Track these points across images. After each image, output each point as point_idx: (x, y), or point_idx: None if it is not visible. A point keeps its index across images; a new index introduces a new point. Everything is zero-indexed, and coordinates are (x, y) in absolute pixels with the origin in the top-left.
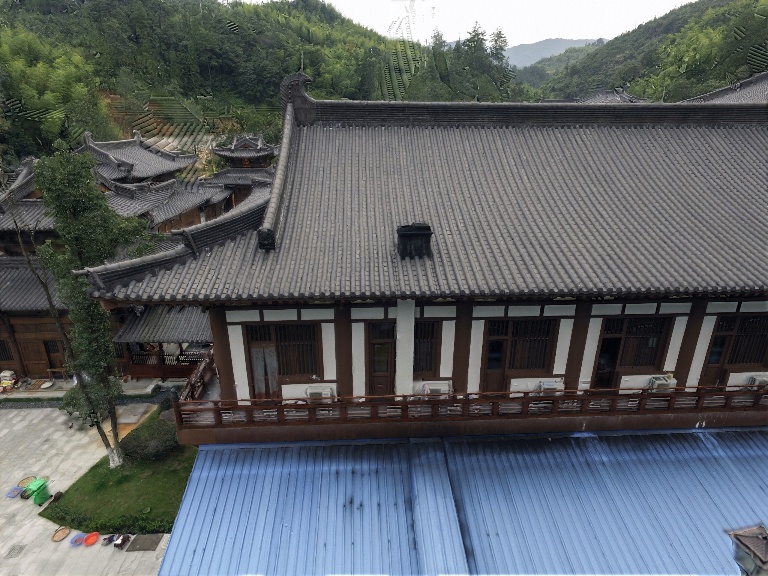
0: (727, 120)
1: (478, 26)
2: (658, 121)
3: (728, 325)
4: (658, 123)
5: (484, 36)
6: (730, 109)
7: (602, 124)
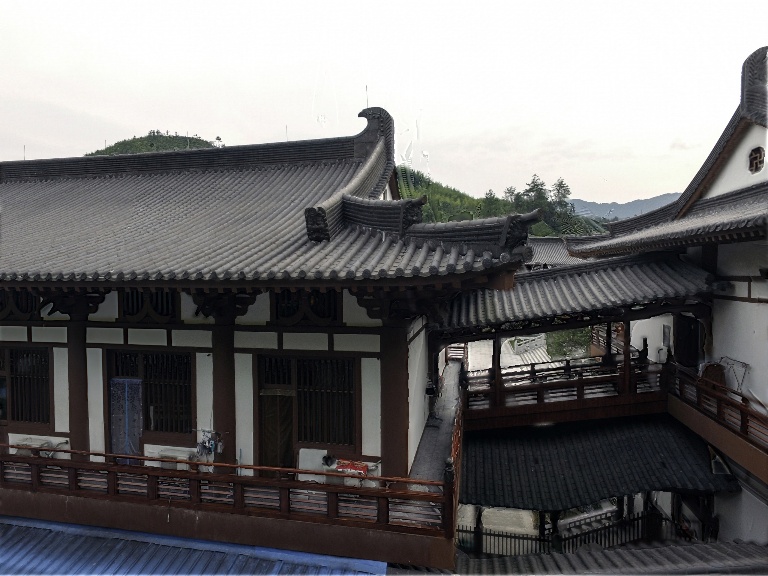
0: (255, 162)
1: (536, 178)
2: (184, 167)
3: (2, 361)
4: (184, 169)
5: (543, 186)
6: (255, 150)
7: (130, 173)
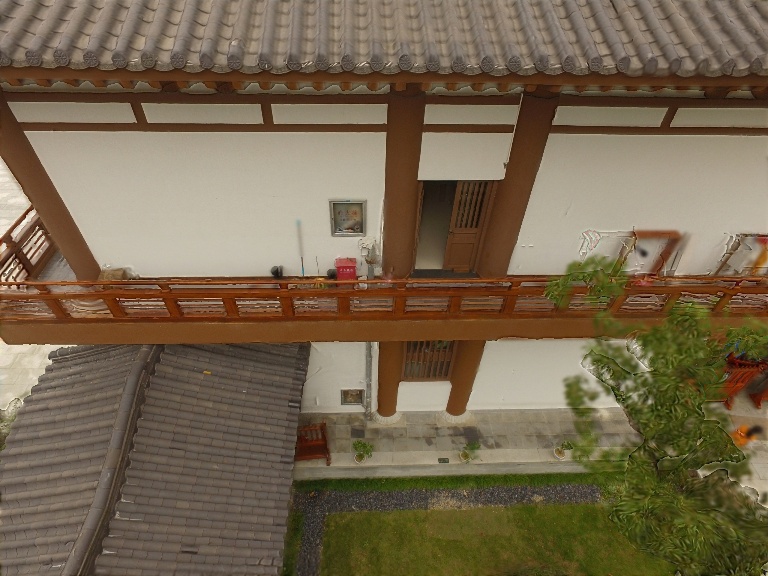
0: None
1: None
2: None
3: None
4: None
5: None
6: None
7: None
